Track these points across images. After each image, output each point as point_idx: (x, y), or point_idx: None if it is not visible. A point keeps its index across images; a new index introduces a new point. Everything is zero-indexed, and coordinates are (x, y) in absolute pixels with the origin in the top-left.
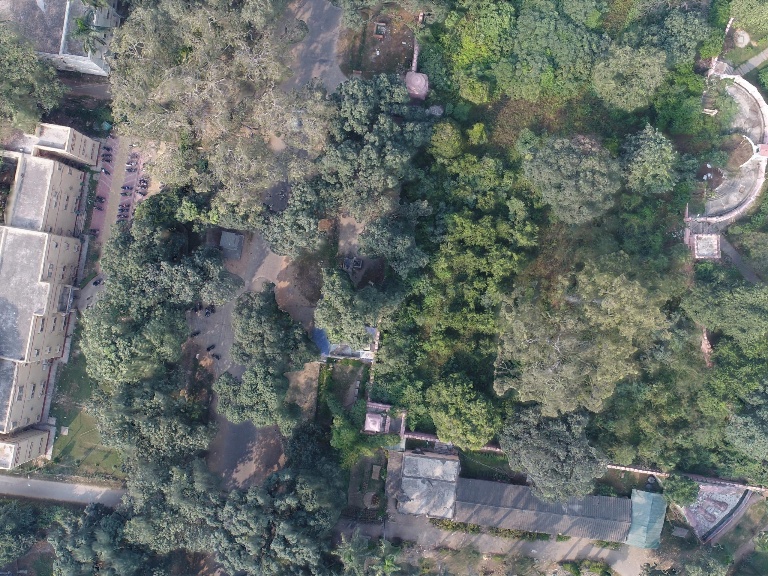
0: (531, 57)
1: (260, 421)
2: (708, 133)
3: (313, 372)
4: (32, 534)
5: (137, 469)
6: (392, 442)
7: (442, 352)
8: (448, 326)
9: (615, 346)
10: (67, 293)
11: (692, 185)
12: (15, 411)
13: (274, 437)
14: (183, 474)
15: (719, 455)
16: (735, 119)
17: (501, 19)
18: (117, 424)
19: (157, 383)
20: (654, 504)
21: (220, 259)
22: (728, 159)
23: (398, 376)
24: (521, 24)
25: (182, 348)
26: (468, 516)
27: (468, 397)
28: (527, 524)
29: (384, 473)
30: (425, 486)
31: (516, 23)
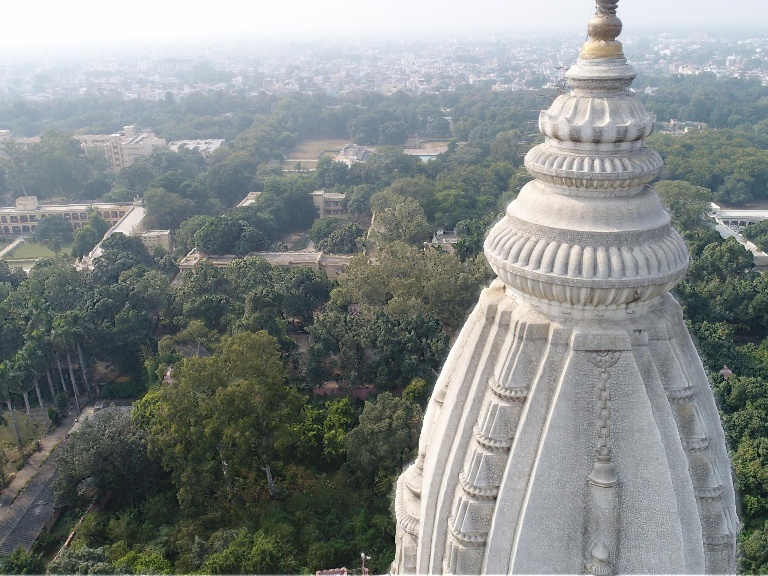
0: None
1: None
2: None
3: None
4: None
5: None
6: (152, 390)
7: None
8: None
9: (214, 357)
10: None
11: None
12: None
13: None
14: None
15: None
16: None
17: None
18: None
19: (222, 287)
20: None
21: (306, 318)
22: None
23: None
24: None
25: None
26: None
27: None
28: None
29: None
30: None
31: None
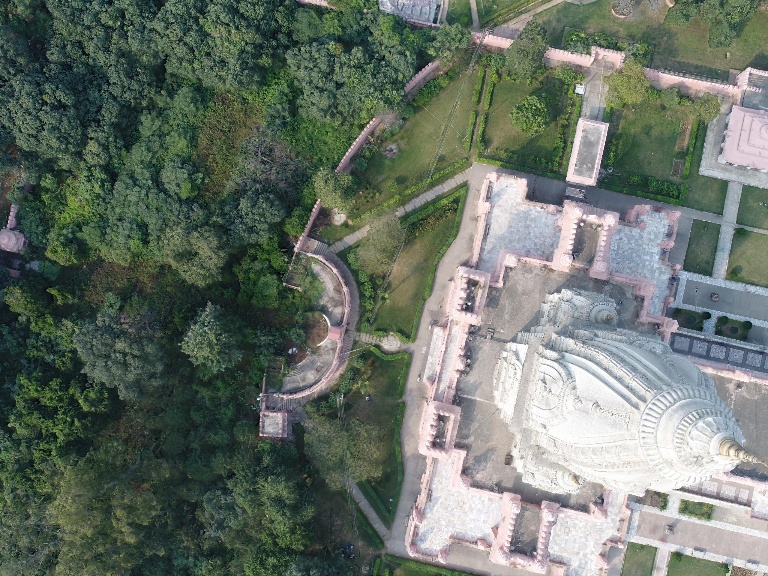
0: (122, 223)
1: None
2: (296, 308)
3: None
4: None
5: None
6: None
7: None
8: None
9: (67, 548)
10: None
11: (265, 361)
12: None
13: None
14: None
15: None
16: (322, 296)
17: (90, 185)
18: None
19: None
20: None
21: None
22: (308, 336)
23: None
24: (116, 190)
25: None
26: None
27: None
28: None
29: None
30: None
31: (113, 188)
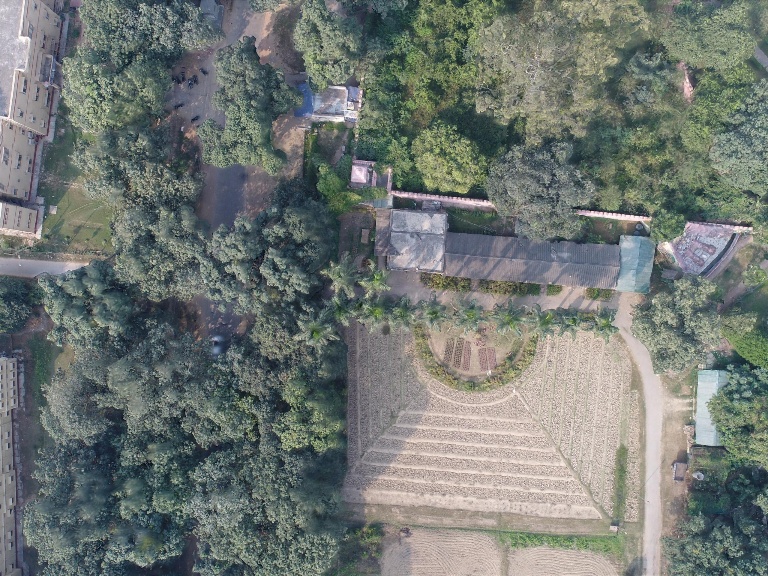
0: None
1: (245, 156)
2: None
3: (298, 139)
4: (24, 304)
5: (124, 211)
6: (379, 193)
7: (426, 109)
8: (430, 80)
9: (593, 33)
10: (49, 64)
11: None
12: (1, 173)
13: (262, 206)
14: (170, 213)
15: (705, 198)
16: None
17: None
18: (103, 167)
19: (141, 130)
20: (642, 247)
21: None
22: None
23: (383, 134)
24: None
25: (167, 121)
26: (458, 269)
27: (452, 138)
28: (517, 274)
29: (373, 235)
30: (414, 240)
31: None
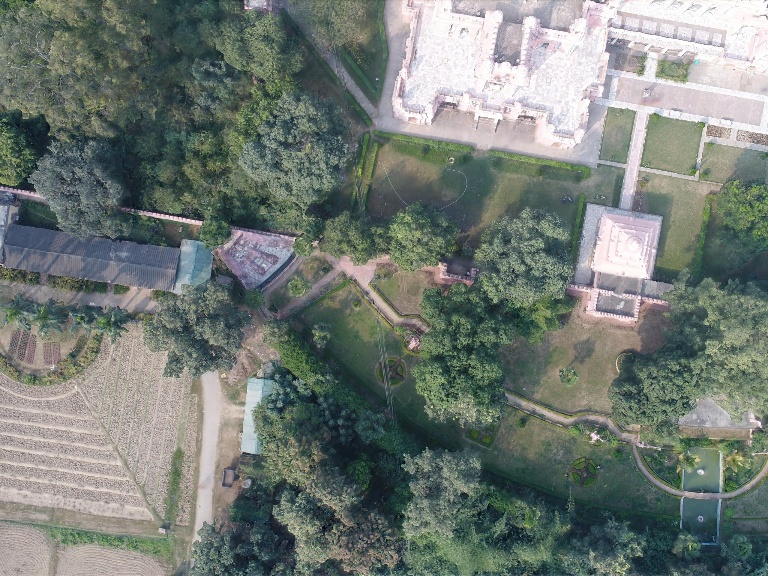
0: None
1: None
2: None
3: None
4: None
5: None
6: None
7: None
8: None
9: (59, 32)
10: None
11: None
12: None
13: None
14: None
15: (268, 207)
16: None
17: None
18: None
19: None
20: (199, 252)
21: None
22: None
23: None
24: None
25: None
26: (18, 261)
27: None
28: (76, 270)
29: None
30: None
31: None
